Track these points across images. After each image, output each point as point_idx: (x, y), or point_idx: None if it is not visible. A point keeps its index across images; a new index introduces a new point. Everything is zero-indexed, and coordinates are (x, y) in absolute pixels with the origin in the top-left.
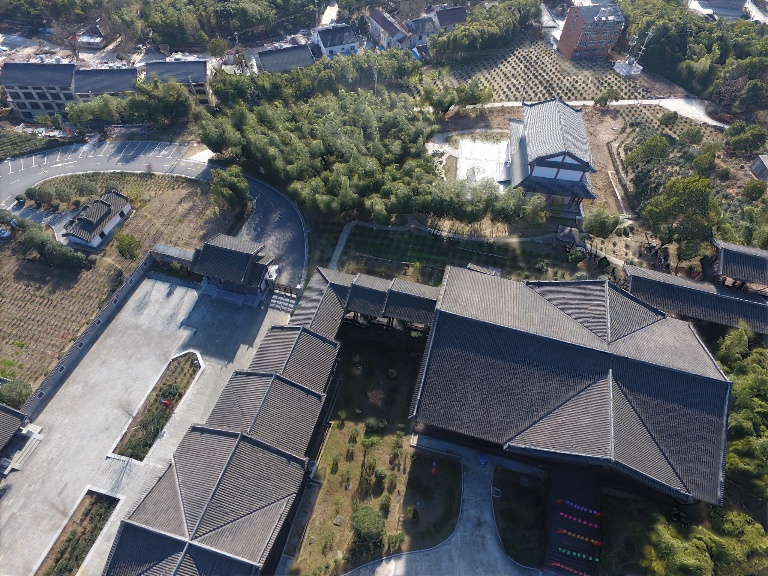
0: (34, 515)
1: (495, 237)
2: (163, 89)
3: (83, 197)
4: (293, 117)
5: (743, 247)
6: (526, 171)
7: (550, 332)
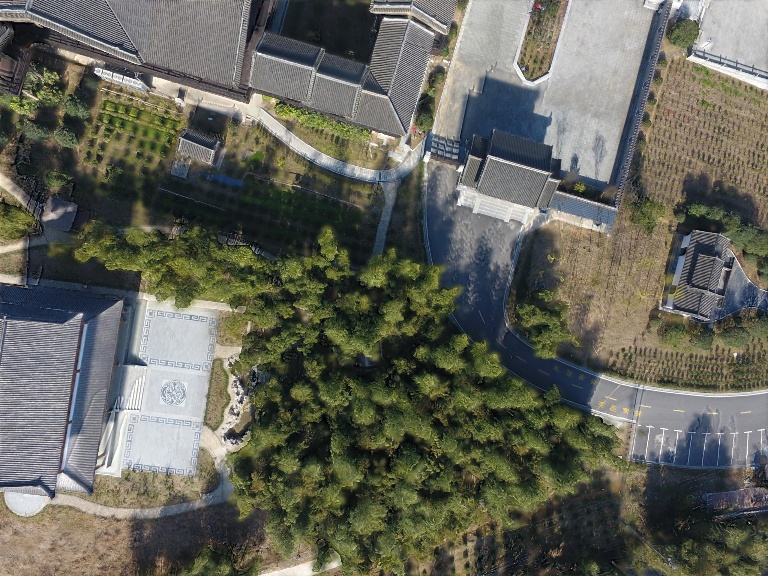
0: None
1: (169, 235)
2: (711, 570)
3: None
4: (477, 491)
5: None
6: (91, 334)
7: None
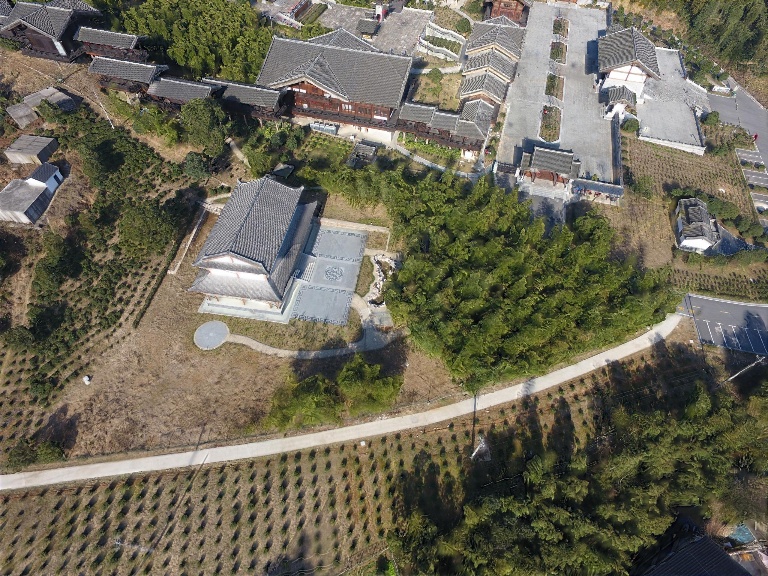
0: (579, 97)
1: None
2: None
3: (745, 269)
4: (577, 323)
5: (187, 98)
6: (298, 213)
7: (351, 57)
